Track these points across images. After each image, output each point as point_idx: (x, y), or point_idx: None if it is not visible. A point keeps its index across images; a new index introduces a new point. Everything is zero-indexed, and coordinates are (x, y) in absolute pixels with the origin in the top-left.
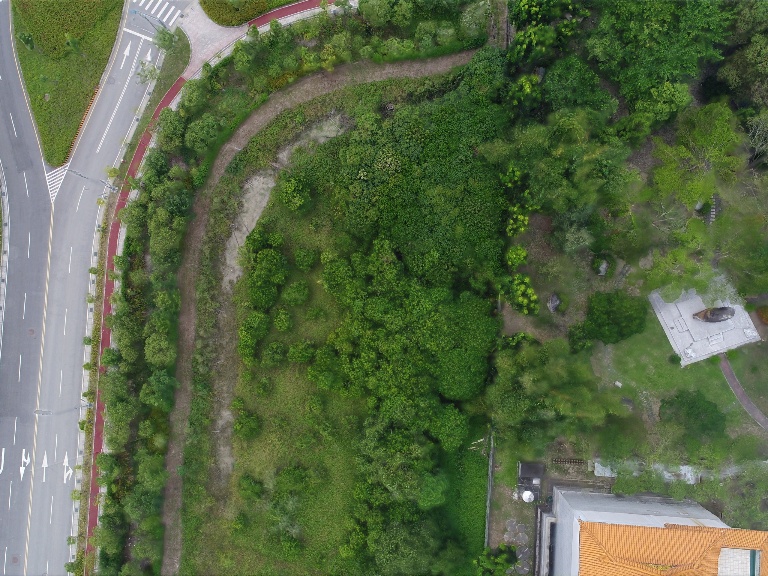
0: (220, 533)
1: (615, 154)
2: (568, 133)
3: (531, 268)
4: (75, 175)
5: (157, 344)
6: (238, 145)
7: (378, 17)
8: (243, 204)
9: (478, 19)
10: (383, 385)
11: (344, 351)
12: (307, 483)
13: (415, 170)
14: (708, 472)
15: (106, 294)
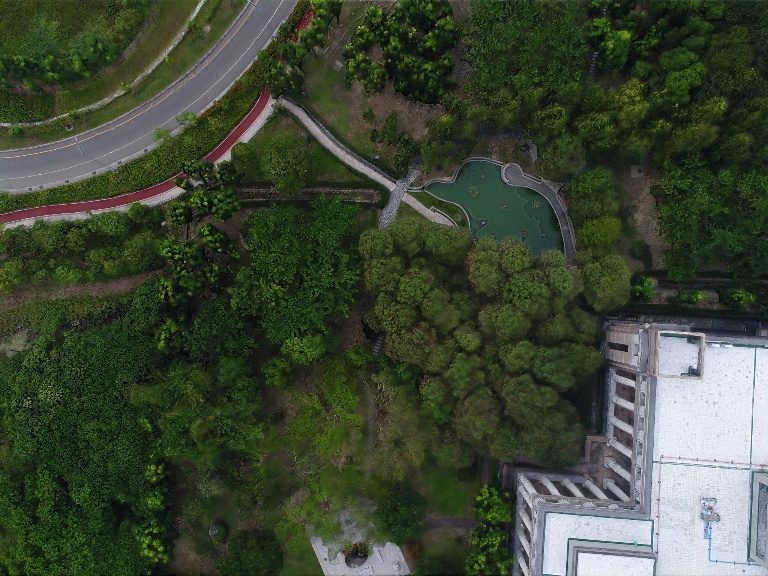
0: None
1: (239, 411)
2: (181, 398)
3: (196, 494)
4: None
5: None
6: None
7: (49, 245)
8: None
9: (140, 253)
10: None
11: (12, 573)
12: None
13: (74, 403)
14: None
15: None
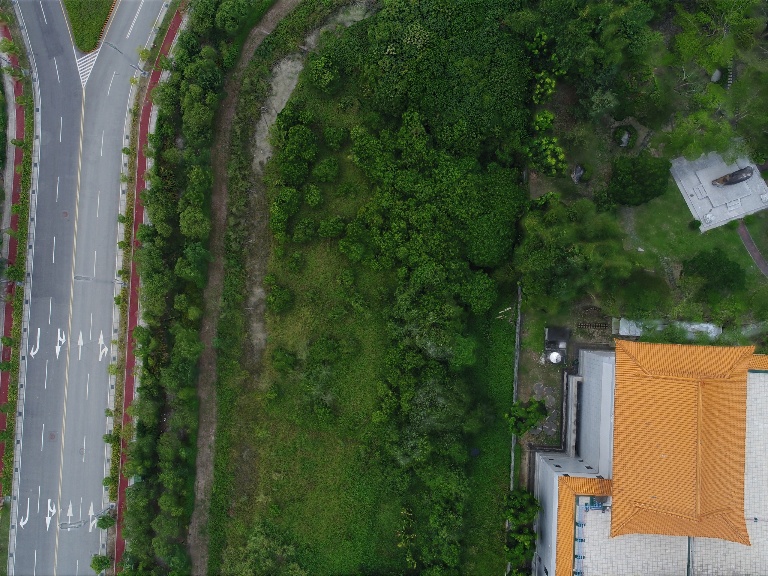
0: (254, 405)
1: (639, 16)
2: None
3: None
4: (106, 60)
5: (192, 216)
6: (267, 29)
7: None
8: (272, 87)
9: None
10: (414, 253)
11: (375, 223)
12: (339, 354)
13: (443, 43)
14: (730, 322)
15: (138, 176)
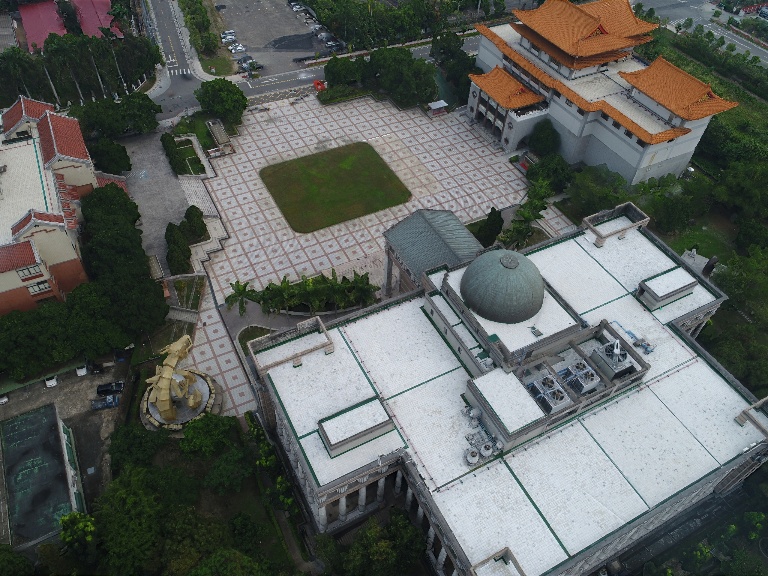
0: None
1: None
2: None
3: None
4: None
5: None
6: None
7: None
8: None
9: None
10: None
11: None
12: None
13: None
14: None
15: None
